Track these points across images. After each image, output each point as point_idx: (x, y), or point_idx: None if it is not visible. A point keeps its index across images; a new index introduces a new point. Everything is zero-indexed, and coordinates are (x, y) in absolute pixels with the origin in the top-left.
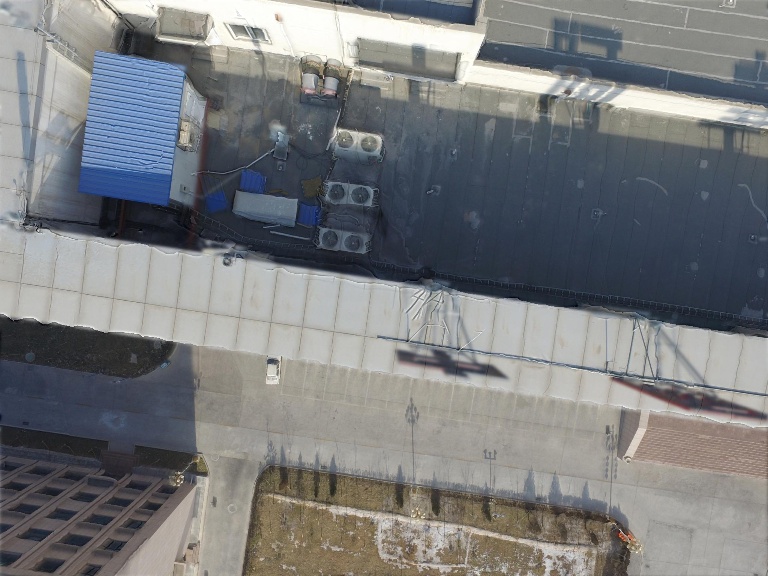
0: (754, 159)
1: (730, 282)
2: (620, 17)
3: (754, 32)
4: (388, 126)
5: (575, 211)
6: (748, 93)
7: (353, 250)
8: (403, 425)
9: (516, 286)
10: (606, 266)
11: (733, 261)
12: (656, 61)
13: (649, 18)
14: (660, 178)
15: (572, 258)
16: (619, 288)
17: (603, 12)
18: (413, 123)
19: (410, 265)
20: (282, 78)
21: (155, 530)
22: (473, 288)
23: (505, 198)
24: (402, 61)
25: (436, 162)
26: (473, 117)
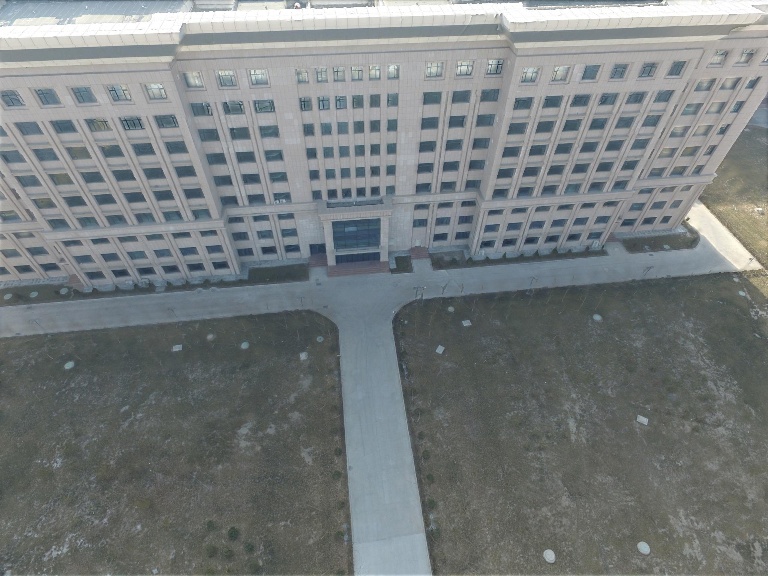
0: None
1: None
2: None
3: None
4: None
5: None
6: None
7: None
8: None
9: (598, 2)
10: None
11: None
12: None
13: None
14: None
15: None
16: None
17: None
18: None
19: None
20: None
21: None
22: (609, 0)
23: None
24: None
25: None
26: None
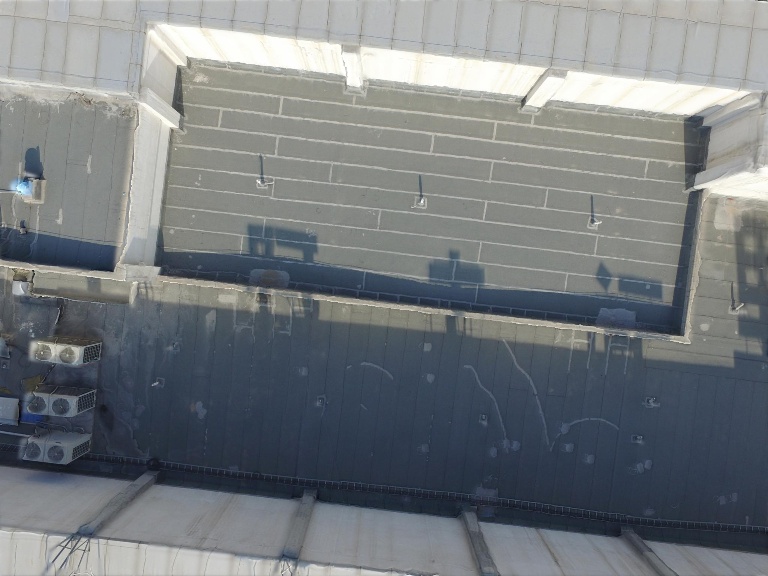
0: (478, 341)
1: (464, 462)
2: (313, 221)
3: (446, 232)
4: (109, 322)
5: (302, 397)
6: (444, 292)
7: (57, 461)
8: None
9: (245, 475)
10: (336, 451)
11: (465, 441)
12: (352, 262)
13: (342, 221)
14: (385, 363)
15: (301, 445)
16: (350, 473)
17: (296, 216)
18: (134, 317)
19: (140, 456)
20: (2, 278)
21: None
22: (202, 479)
23: (231, 387)
24: (77, 286)
25: (159, 354)
26: (193, 309)
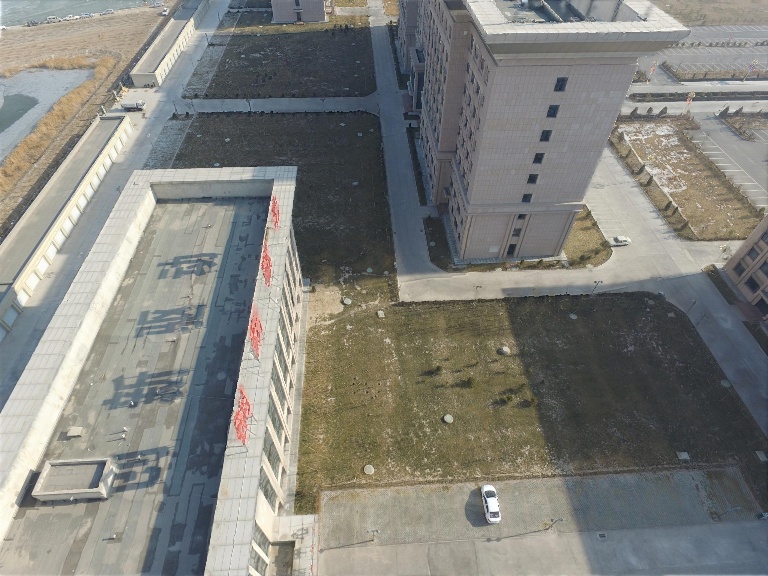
0: None
1: None
2: None
3: None
4: None
5: None
6: None
7: None
8: (608, 189)
9: None
10: None
11: None
12: None
13: None
14: None
15: None
16: None
17: None
18: None
19: None
20: None
21: (759, 224)
22: None
23: None
24: None
25: None
26: None
